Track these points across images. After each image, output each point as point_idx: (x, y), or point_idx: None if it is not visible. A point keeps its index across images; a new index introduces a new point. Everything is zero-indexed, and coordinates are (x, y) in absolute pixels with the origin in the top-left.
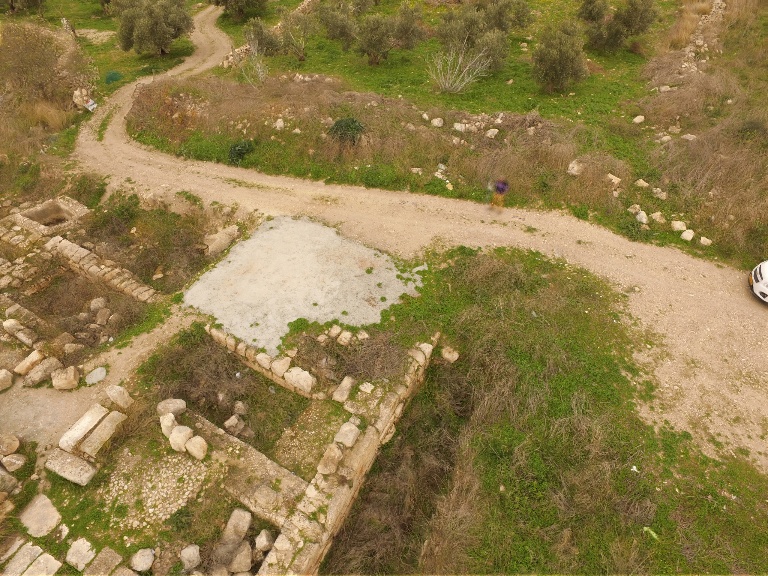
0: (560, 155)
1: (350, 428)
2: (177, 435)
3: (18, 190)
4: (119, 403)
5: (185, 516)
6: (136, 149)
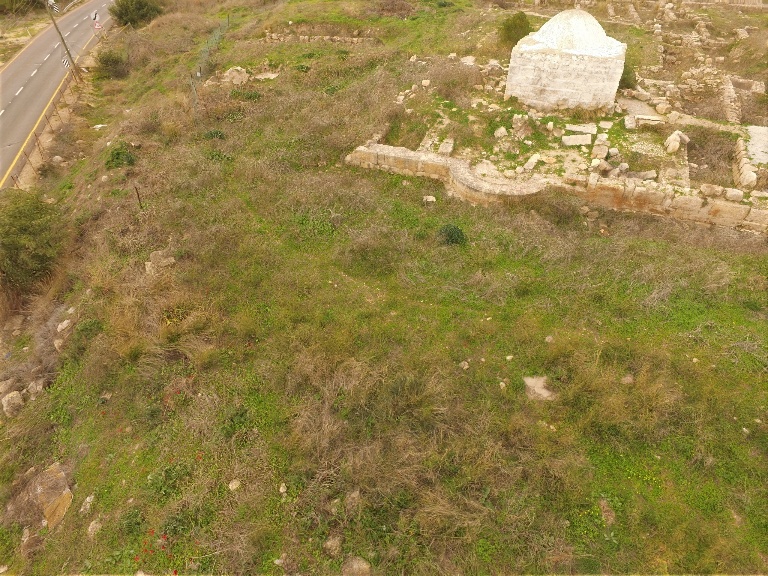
0: None
1: (739, 192)
2: (674, 135)
3: (743, 73)
4: (670, 119)
5: (639, 155)
6: None
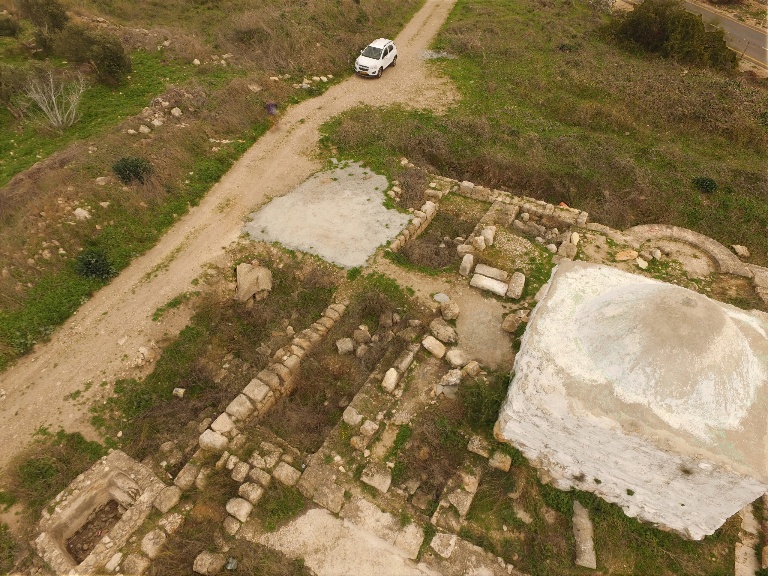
0: (242, 86)
1: (465, 182)
2: (490, 231)
3: None
4: None
5: None
6: None
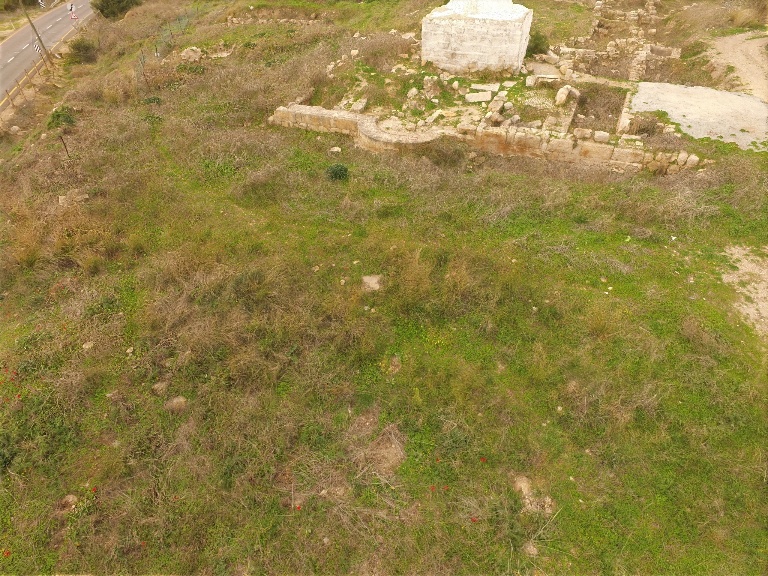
0: None
1: (606, 133)
2: (562, 89)
3: (670, 43)
4: (565, 76)
5: (530, 108)
6: (757, 50)
